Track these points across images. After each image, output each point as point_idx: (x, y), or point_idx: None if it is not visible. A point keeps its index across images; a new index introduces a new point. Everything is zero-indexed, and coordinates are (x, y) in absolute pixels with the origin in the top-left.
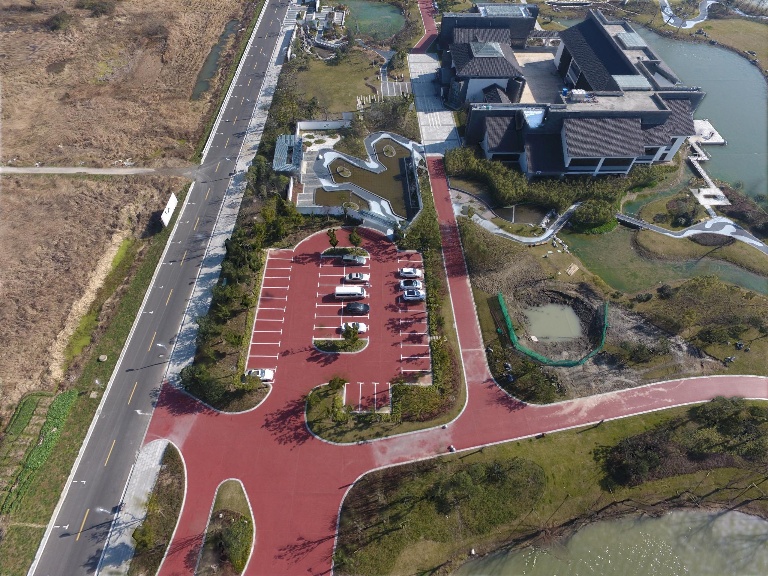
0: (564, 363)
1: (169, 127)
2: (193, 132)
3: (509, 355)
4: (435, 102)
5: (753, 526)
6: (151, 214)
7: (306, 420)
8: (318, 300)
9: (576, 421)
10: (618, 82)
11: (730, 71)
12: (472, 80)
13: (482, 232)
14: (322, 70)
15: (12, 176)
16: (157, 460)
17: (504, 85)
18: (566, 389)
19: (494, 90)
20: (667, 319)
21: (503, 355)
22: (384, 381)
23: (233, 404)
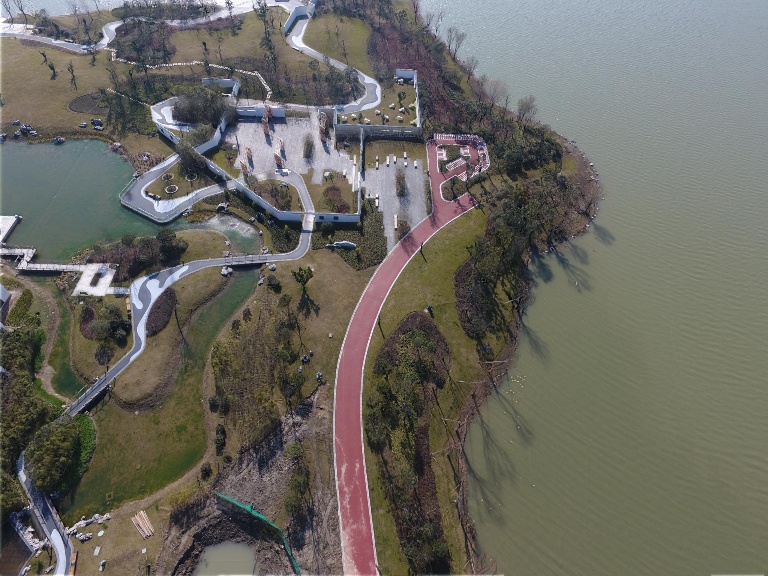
0: None
1: None
2: None
3: None
4: None
5: (476, 436)
6: None
7: None
8: None
9: None
10: None
11: None
12: None
13: None
14: None
15: None
16: None
17: None
18: None
19: None
20: None
21: None
22: None
23: None
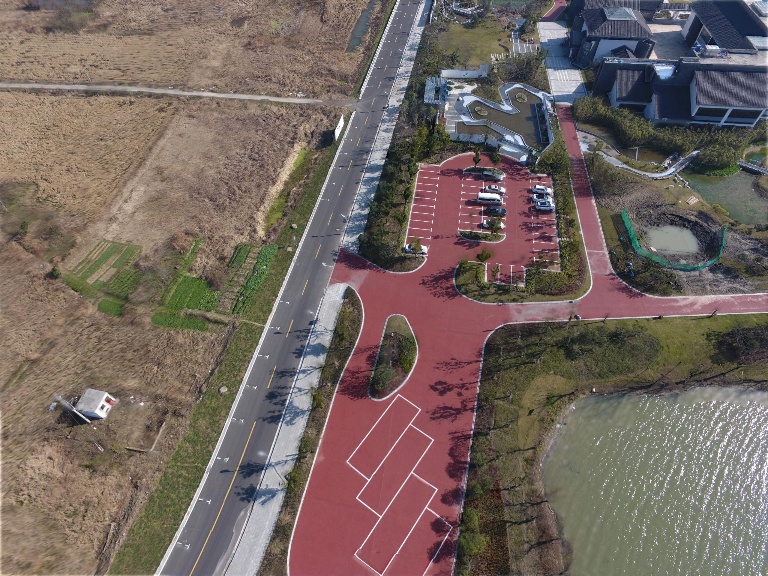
0: (682, 268)
1: (332, 70)
2: (351, 75)
3: (631, 257)
4: (563, 62)
5: None
6: (322, 132)
7: (455, 284)
8: (462, 203)
9: (691, 311)
10: (752, 42)
11: None
12: (603, 41)
13: (607, 165)
14: (460, 32)
15: (214, 99)
16: (340, 296)
17: (633, 47)
18: (683, 287)
19: (623, 51)
20: None
21: (625, 256)
22: (519, 265)
23: (397, 266)
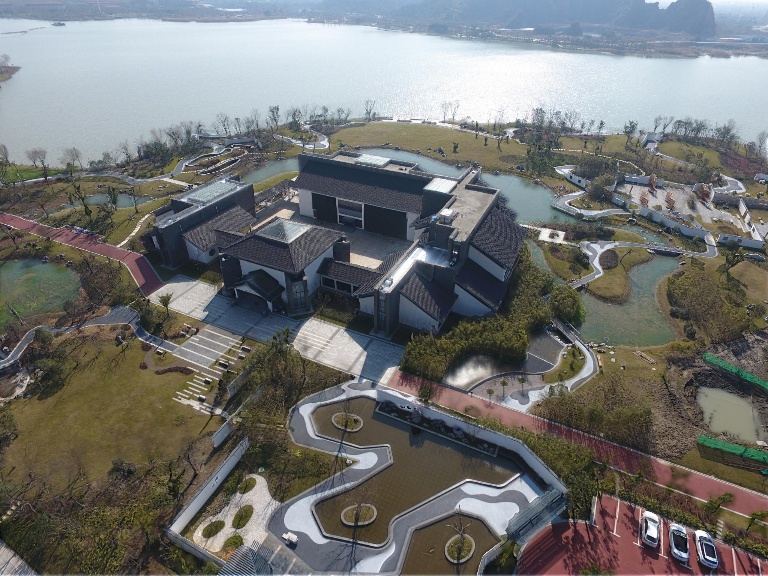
0: None
1: None
2: None
3: None
4: (277, 323)
5: None
6: None
7: None
8: None
9: None
10: (438, 191)
11: None
12: (306, 269)
13: (569, 401)
14: (45, 413)
15: None
16: None
17: (330, 254)
18: None
19: (334, 264)
20: None
21: None
22: None
23: None
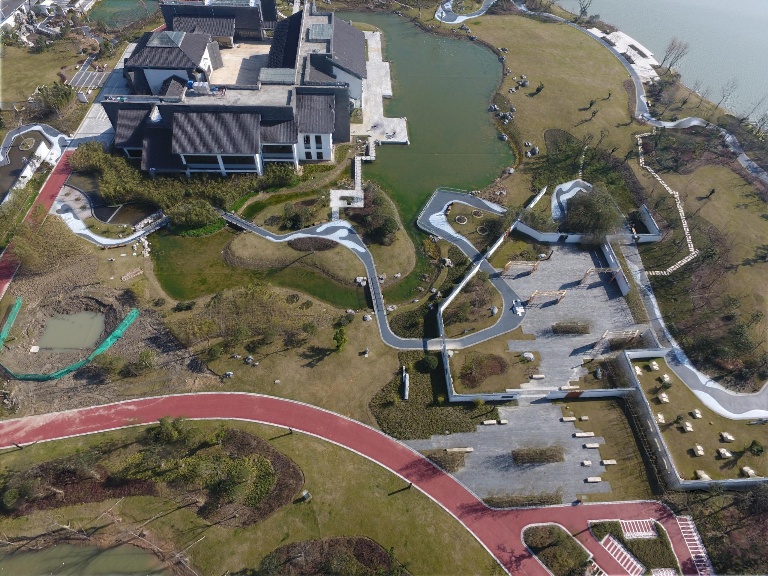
0: (36, 377)
1: None
2: None
3: None
4: (121, 94)
5: (137, 561)
6: None
7: None
8: None
9: (6, 442)
10: (261, 75)
11: (471, 68)
12: (147, 71)
13: (62, 232)
14: (19, 58)
15: None
16: None
17: (185, 77)
18: (19, 406)
19: (169, 82)
20: (172, 330)
21: None
22: None
23: None
